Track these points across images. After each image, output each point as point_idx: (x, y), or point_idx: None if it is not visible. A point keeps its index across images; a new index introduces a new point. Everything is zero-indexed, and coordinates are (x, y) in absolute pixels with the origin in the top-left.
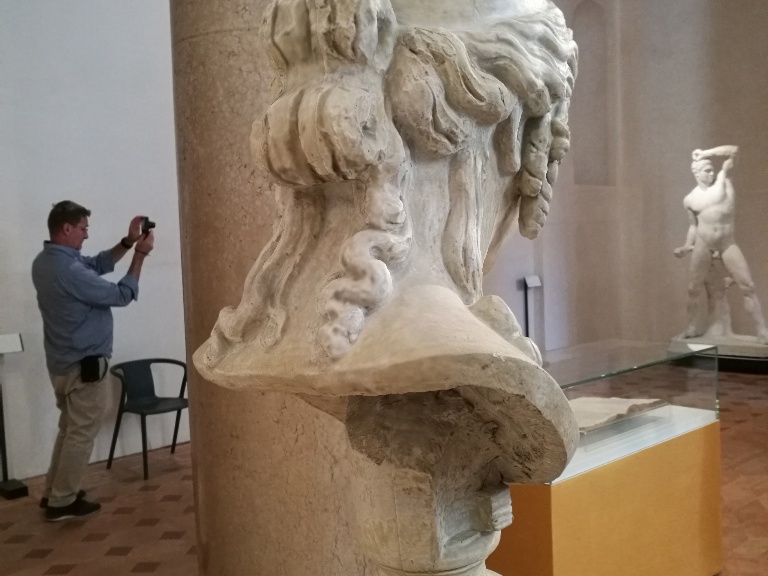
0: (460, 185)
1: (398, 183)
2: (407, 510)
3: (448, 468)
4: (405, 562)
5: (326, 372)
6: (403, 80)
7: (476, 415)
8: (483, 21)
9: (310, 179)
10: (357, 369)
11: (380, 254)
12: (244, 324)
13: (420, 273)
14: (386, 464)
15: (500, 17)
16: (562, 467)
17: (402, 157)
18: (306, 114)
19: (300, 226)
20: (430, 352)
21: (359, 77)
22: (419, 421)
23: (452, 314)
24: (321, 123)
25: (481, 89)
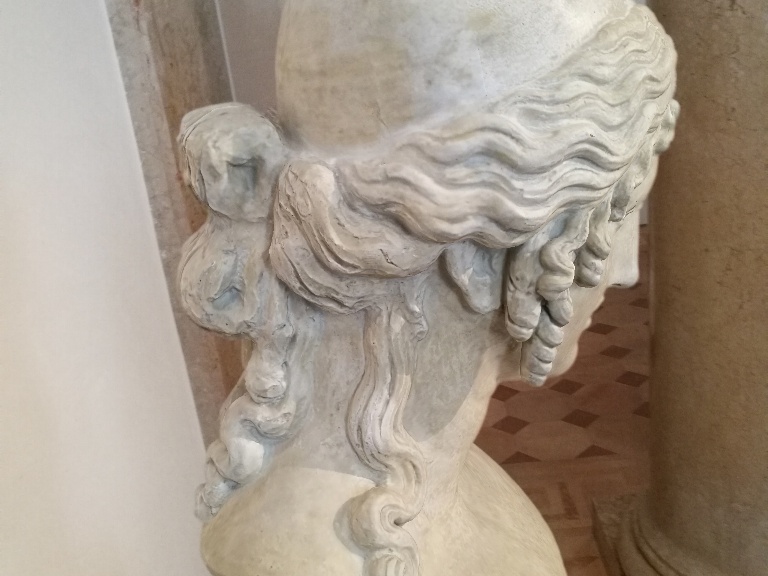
0: (369, 347)
1: (279, 349)
2: None
3: None
4: None
5: None
6: None
7: None
8: (393, 138)
9: None
10: None
11: (255, 426)
12: None
13: (303, 449)
14: None
15: (413, 131)
16: None
17: (275, 325)
18: None
19: (250, 348)
20: (227, 572)
21: (226, 233)
22: None
23: (291, 521)
24: None
25: (348, 255)
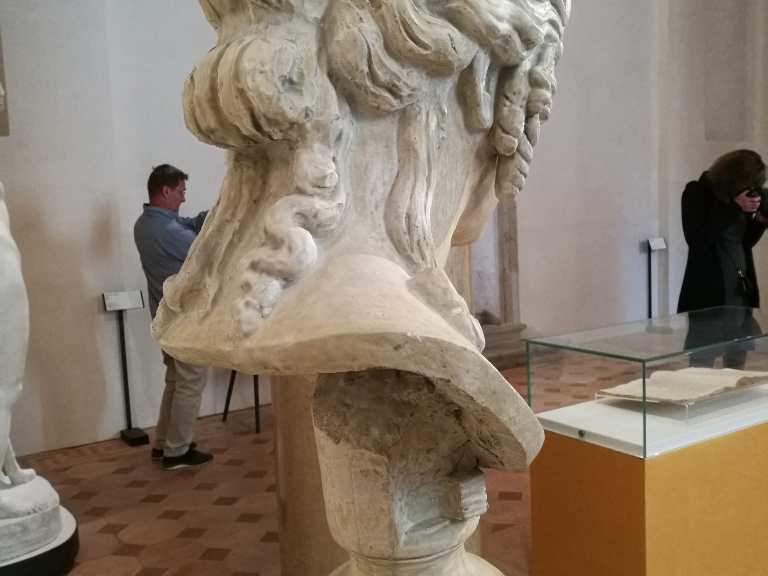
0: (408, 144)
1: (330, 143)
2: (364, 493)
3: (409, 451)
4: (364, 547)
5: (238, 348)
6: (336, 28)
7: (438, 395)
8: None
9: (239, 140)
10: (263, 346)
11: (305, 221)
12: (181, 294)
13: (353, 242)
14: (343, 444)
15: None
16: (524, 456)
17: (334, 114)
18: (223, 69)
19: (238, 190)
20: (335, 330)
21: (285, 27)
22: (379, 399)
23: (376, 287)
24: (237, 78)
25: (425, 36)
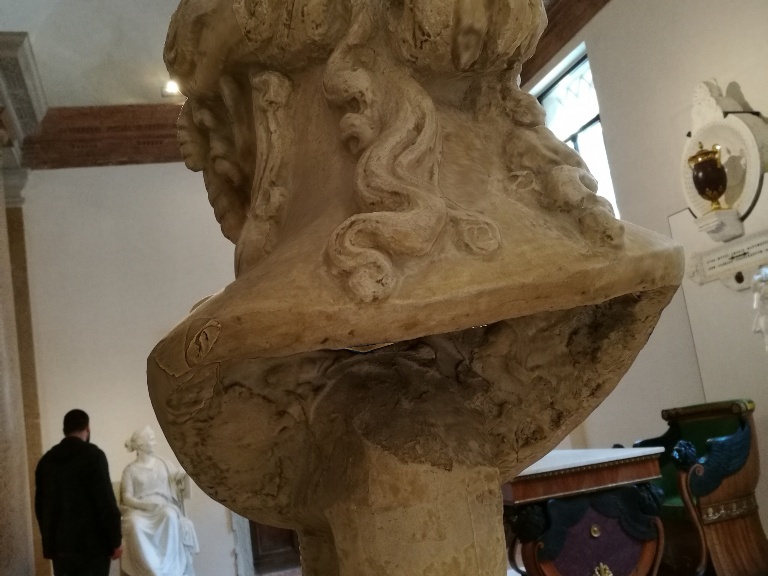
0: None
1: None
2: (483, 525)
3: None
4: None
5: (619, 260)
6: None
7: (490, 398)
8: None
9: (477, 54)
10: (653, 252)
11: None
12: (444, 223)
13: None
14: (458, 467)
15: None
16: None
17: None
18: None
19: None
20: None
21: None
22: (458, 411)
23: None
24: None
25: None
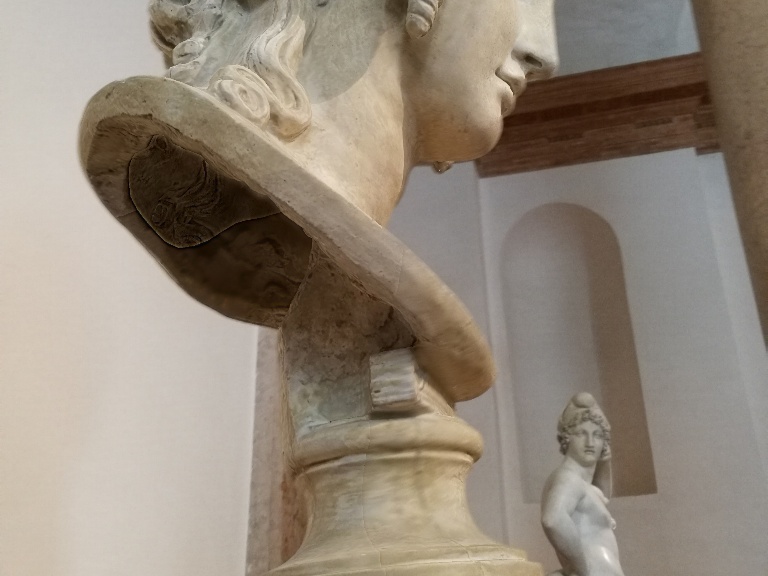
0: None
1: (207, 27)
2: None
3: (311, 321)
4: None
5: None
6: None
7: None
8: None
9: None
10: None
11: None
12: None
13: None
14: None
15: None
16: (331, 243)
17: (207, 4)
18: None
19: None
20: None
21: None
22: None
23: None
24: None
25: None
